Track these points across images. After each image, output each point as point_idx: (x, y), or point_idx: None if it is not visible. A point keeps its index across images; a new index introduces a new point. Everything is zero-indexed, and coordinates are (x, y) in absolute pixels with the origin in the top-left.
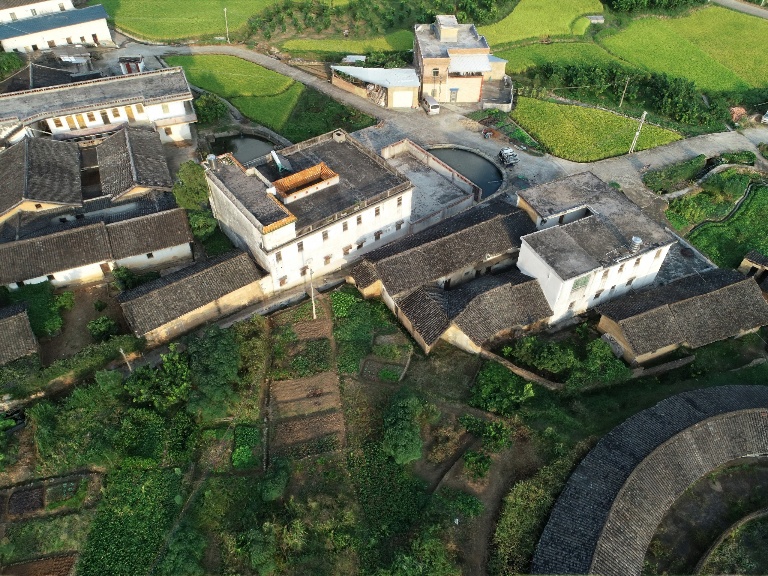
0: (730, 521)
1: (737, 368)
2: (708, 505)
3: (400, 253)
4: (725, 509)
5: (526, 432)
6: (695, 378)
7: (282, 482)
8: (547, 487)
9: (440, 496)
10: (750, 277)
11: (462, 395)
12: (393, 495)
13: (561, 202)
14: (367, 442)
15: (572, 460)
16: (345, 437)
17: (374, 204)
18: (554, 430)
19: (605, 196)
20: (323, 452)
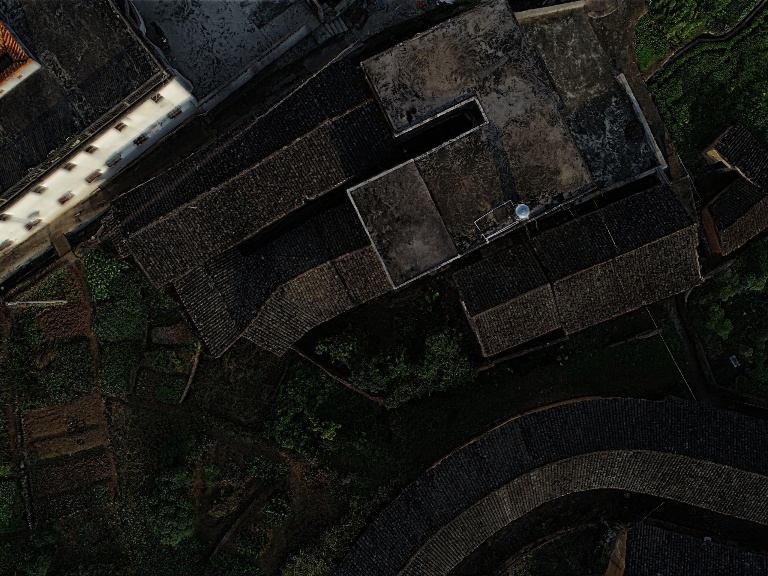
0: (529, 539)
1: (620, 341)
2: (513, 522)
3: (162, 217)
4: (529, 525)
5: (323, 477)
6: (560, 362)
7: (41, 569)
8: (329, 554)
9: (216, 564)
10: (691, 224)
11: (258, 417)
12: (169, 558)
13: (433, 91)
14: (140, 494)
15: (365, 516)
16: (117, 485)
17: (105, 128)
18: (354, 477)
19: (512, 72)
20: (93, 506)
